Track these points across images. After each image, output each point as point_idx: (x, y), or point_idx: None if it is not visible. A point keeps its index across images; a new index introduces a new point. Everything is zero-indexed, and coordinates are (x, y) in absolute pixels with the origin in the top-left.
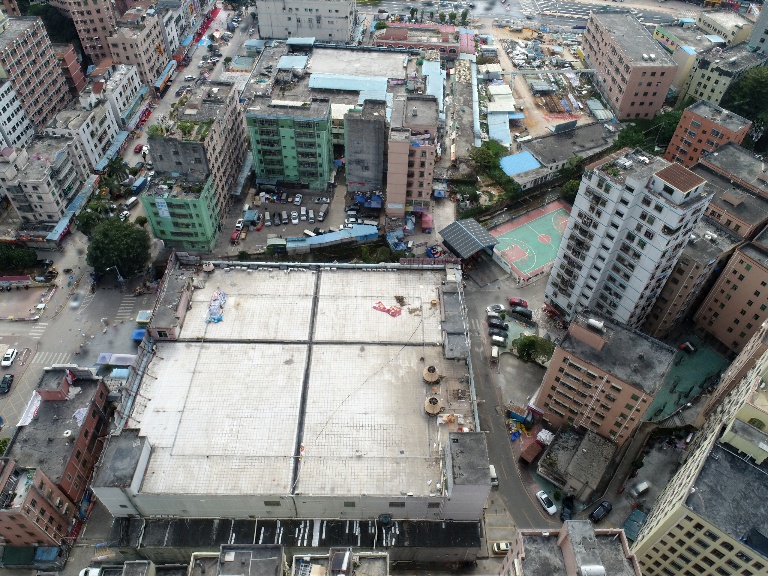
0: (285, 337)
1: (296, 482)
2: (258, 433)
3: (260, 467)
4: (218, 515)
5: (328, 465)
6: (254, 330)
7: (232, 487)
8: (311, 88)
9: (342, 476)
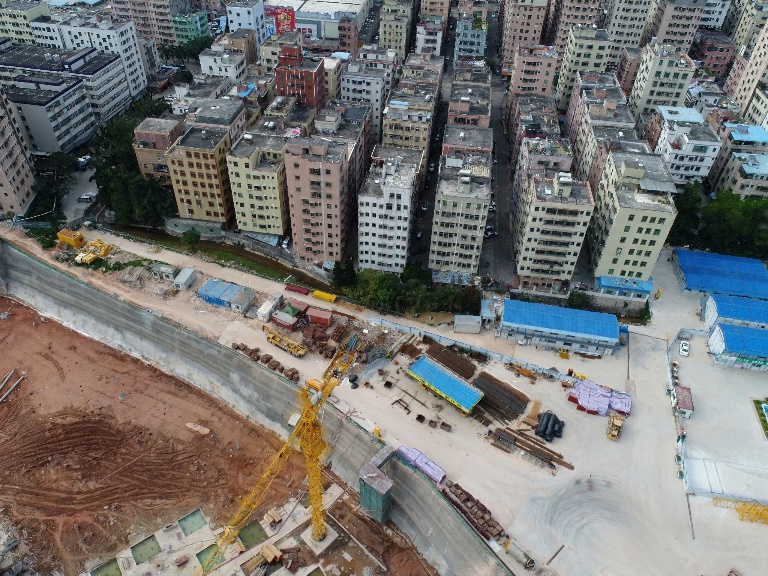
0: (301, 3)
1: (360, 4)
2: (341, 7)
3: (353, 7)
4: (360, 27)
5: (356, 1)
6: (295, 6)
7: (358, 10)
8: (92, 5)
9: (360, 0)
